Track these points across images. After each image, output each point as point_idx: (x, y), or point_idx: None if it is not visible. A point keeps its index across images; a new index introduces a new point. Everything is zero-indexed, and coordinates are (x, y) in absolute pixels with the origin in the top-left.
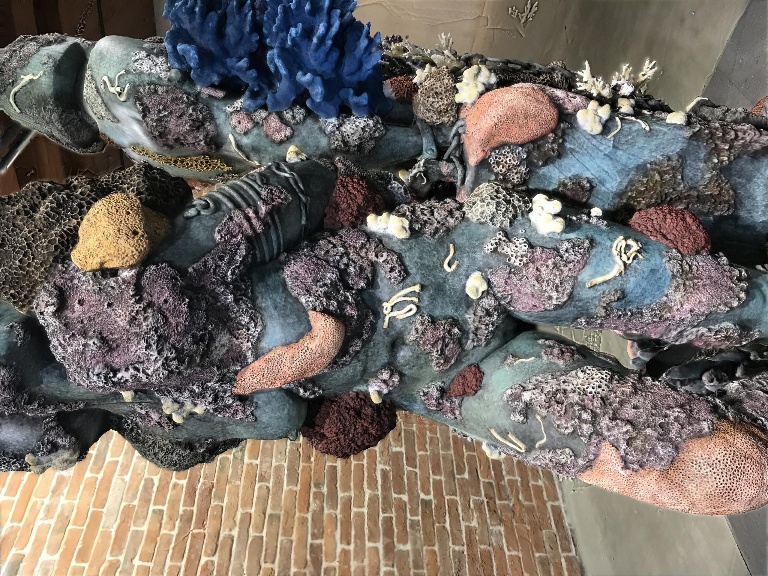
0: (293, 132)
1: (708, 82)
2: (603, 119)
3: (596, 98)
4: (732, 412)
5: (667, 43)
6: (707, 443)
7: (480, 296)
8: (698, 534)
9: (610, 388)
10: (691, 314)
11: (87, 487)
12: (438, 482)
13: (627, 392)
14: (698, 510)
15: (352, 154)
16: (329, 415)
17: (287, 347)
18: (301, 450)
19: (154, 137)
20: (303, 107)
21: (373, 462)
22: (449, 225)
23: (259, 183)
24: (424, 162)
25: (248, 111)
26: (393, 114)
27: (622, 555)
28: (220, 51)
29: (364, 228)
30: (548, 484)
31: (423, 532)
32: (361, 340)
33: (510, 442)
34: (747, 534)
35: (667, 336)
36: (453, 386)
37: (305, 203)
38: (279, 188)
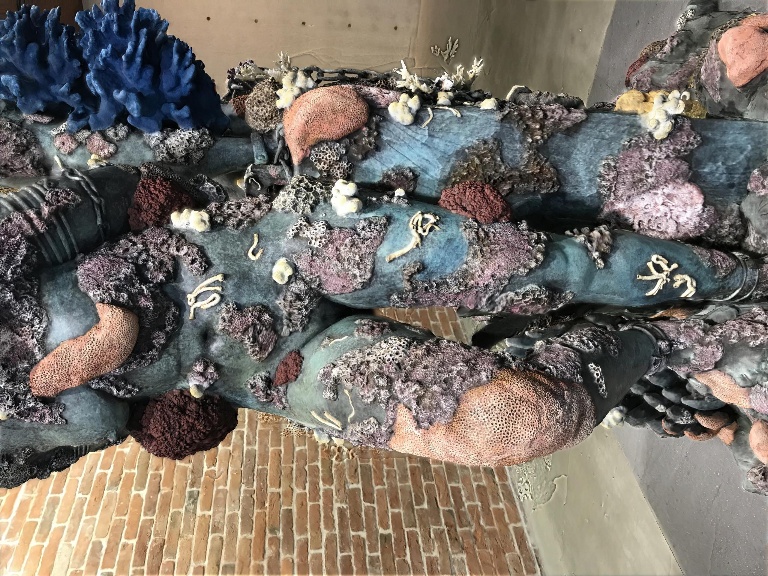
0: (117, 148)
1: (590, 89)
2: (413, 110)
3: (416, 94)
4: (516, 362)
5: (563, 61)
6: (483, 391)
7: (288, 281)
8: (640, 533)
9: (407, 354)
10: (493, 279)
11: (32, 557)
12: (397, 515)
13: (419, 354)
14: (487, 460)
15: (180, 165)
16: (153, 415)
17: (74, 340)
18: (255, 496)
19: None
20: (126, 124)
21: (329, 501)
22: (255, 217)
23: (45, 187)
24: (252, 167)
25: (71, 132)
26: (236, 130)
27: (580, 568)
28: (45, 80)
29: (169, 226)
30: (509, 506)
31: (383, 568)
32: (164, 332)
33: (329, 422)
34: (670, 522)
35: (481, 305)
36: (277, 375)
37: (99, 204)
38: (66, 190)
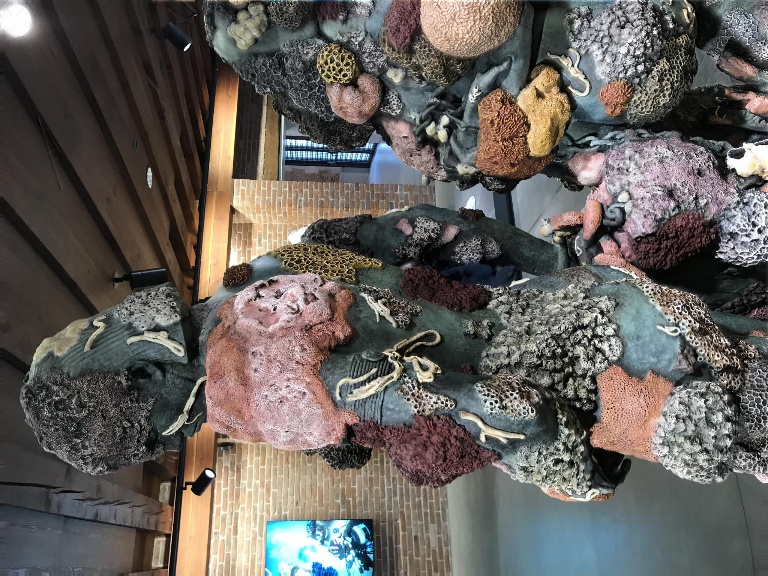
0: None
1: None
2: None
3: None
4: None
5: None
6: None
7: None
8: None
9: None
10: None
11: None
12: None
13: None
14: None
15: None
16: None
17: None
18: None
19: None
20: None
21: None
22: None
23: None
24: None
25: None
26: None
27: None
28: None
29: None
30: None
31: None
32: None
33: None
34: None
35: None
36: None
37: None
38: None
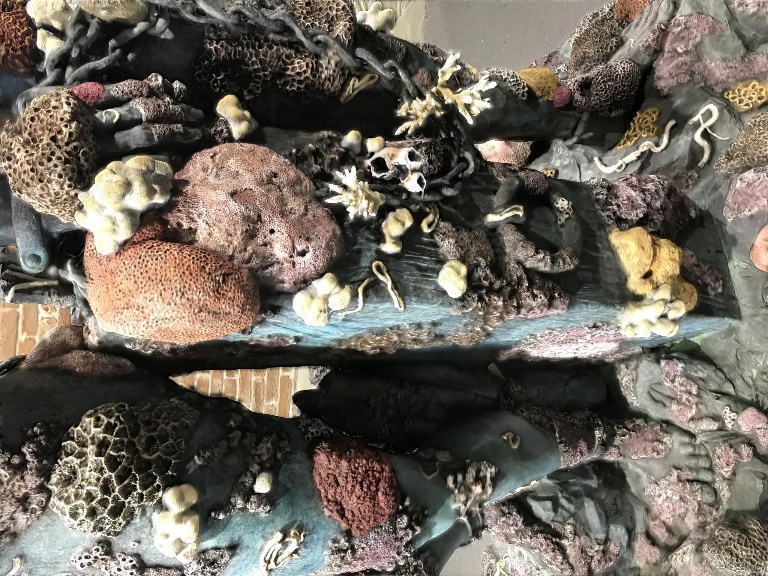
0: None
1: None
2: None
3: None
4: None
5: None
6: None
7: None
8: None
9: None
10: None
11: None
12: None
13: None
14: None
15: None
16: None
17: None
18: None
19: None
20: None
21: None
22: (15, 529)
23: None
24: (12, 299)
25: None
26: None
27: None
28: None
29: None
30: None
31: None
32: None
33: None
34: None
35: None
36: None
37: None
38: None
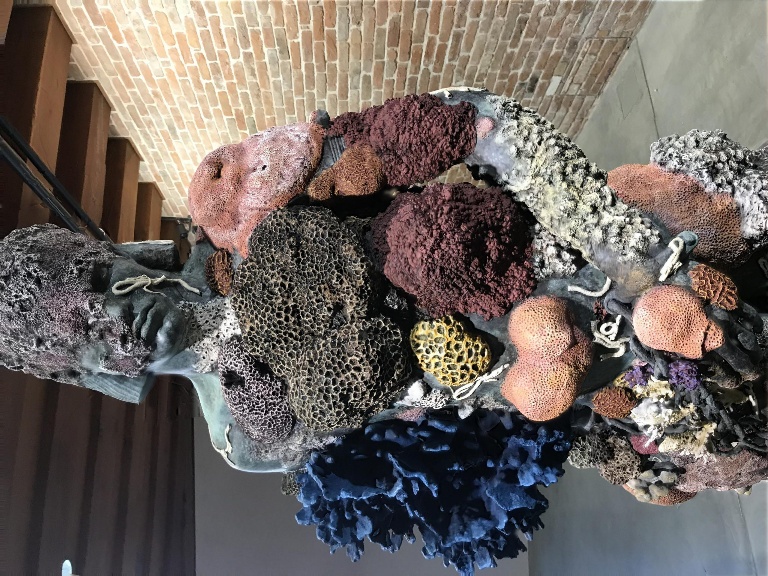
0: None
1: None
2: None
3: None
4: None
5: None
6: None
7: None
8: None
9: None
10: None
11: None
12: None
13: None
14: None
15: None
16: None
17: None
18: None
19: None
20: None
21: None
22: None
23: None
24: None
25: None
26: None
27: None
28: None
29: None
30: None
31: None
32: None
33: None
34: None
35: None
36: None
37: None
38: None
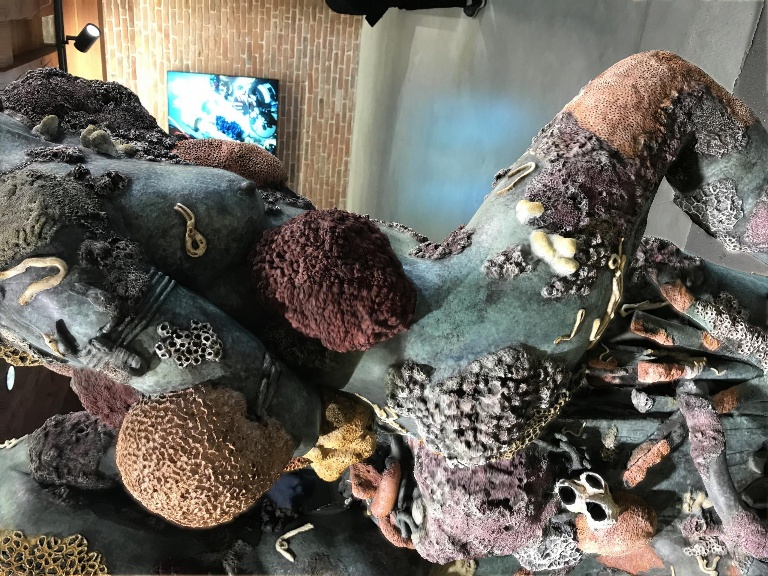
0: None
1: None
2: None
3: None
4: None
5: None
6: None
7: None
8: None
9: None
10: None
11: None
12: None
13: None
14: None
15: None
16: None
17: None
18: None
19: (45, 436)
20: None
21: None
22: None
23: None
24: None
25: None
26: None
27: None
28: None
29: None
30: None
31: None
32: None
33: None
34: None
35: None
36: (444, 243)
37: None
38: None
